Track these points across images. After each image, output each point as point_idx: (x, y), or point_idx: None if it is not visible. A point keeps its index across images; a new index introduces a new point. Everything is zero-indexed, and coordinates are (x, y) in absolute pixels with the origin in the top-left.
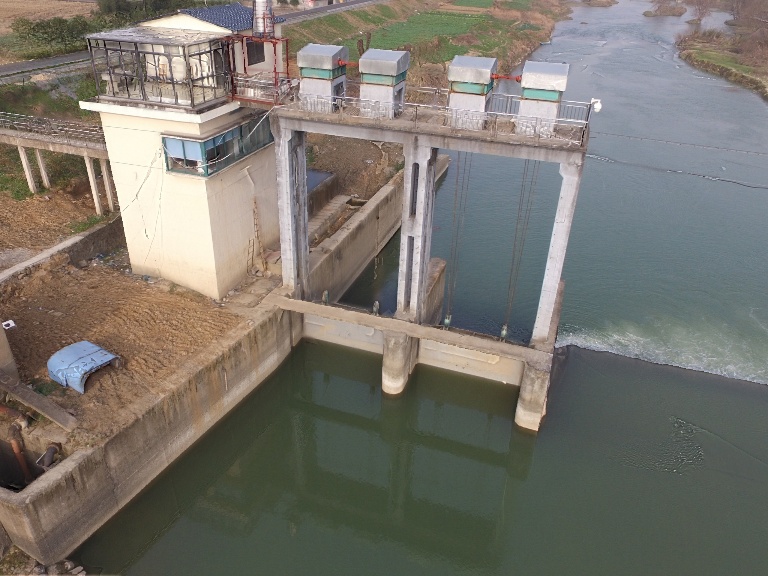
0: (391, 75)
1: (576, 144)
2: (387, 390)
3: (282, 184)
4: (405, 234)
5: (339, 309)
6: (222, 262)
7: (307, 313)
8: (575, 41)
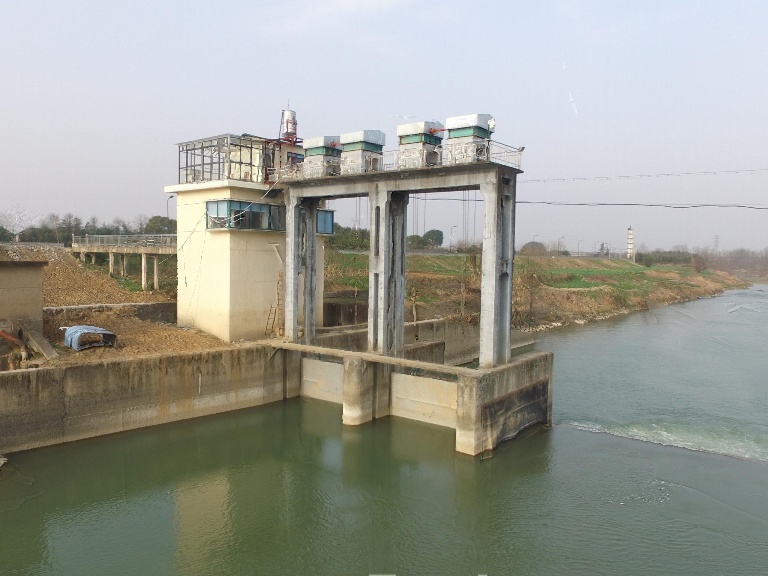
0: (360, 141)
1: (483, 160)
2: (345, 421)
3: (289, 243)
4: (372, 272)
5: (318, 347)
6: (238, 310)
7: (290, 348)
8: (742, 299)
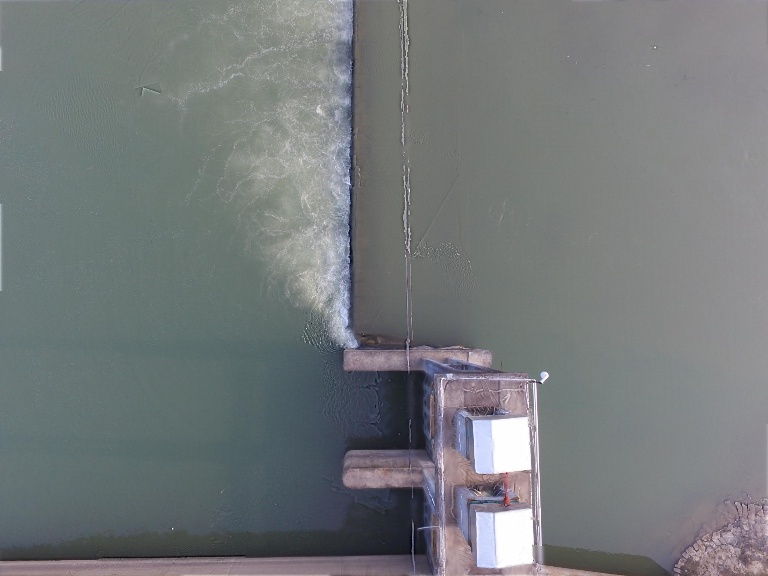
0: None
1: None
2: None
3: None
4: None
5: None
6: None
7: None
8: None
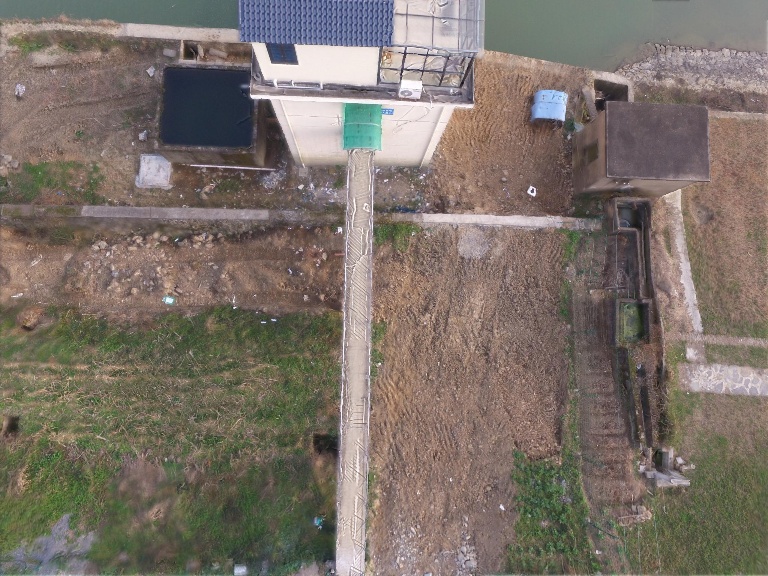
0: None
1: None
2: None
3: None
4: None
5: None
6: None
7: None
8: None
